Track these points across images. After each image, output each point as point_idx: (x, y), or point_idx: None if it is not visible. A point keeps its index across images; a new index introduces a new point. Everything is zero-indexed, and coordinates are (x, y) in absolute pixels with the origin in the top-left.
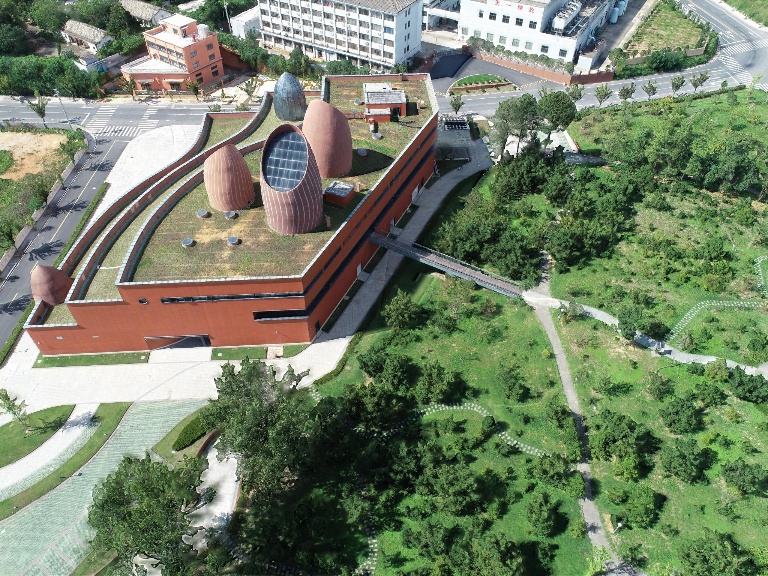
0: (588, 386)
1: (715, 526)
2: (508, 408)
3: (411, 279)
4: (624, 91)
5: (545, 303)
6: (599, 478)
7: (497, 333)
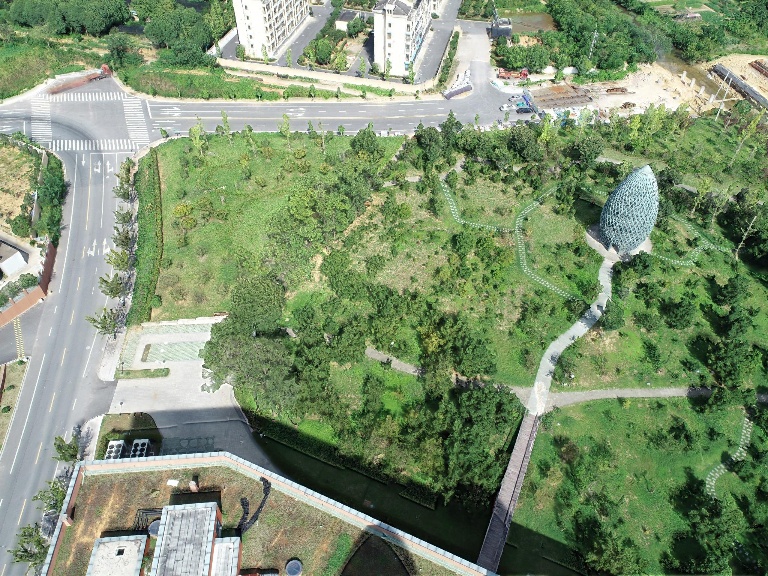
0: (654, 376)
1: (765, 322)
2: (706, 449)
3: (514, 553)
4: (119, 241)
5: (544, 395)
6: (755, 386)
7: (600, 449)
